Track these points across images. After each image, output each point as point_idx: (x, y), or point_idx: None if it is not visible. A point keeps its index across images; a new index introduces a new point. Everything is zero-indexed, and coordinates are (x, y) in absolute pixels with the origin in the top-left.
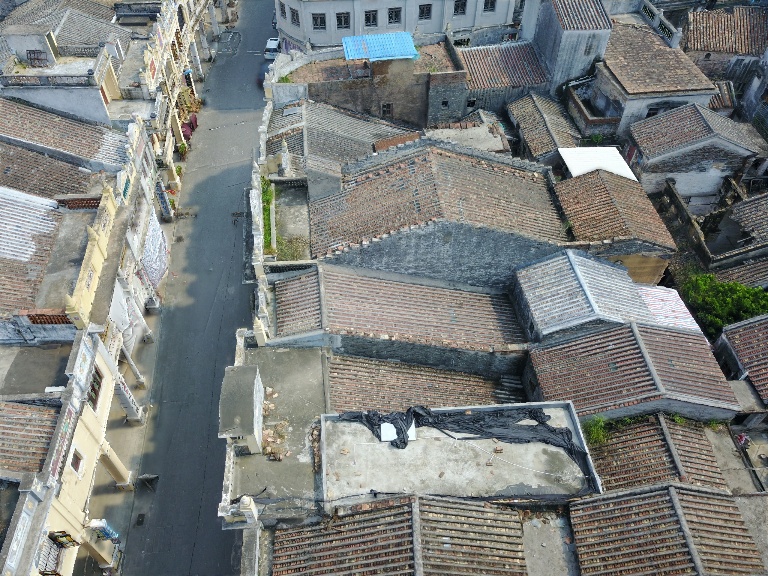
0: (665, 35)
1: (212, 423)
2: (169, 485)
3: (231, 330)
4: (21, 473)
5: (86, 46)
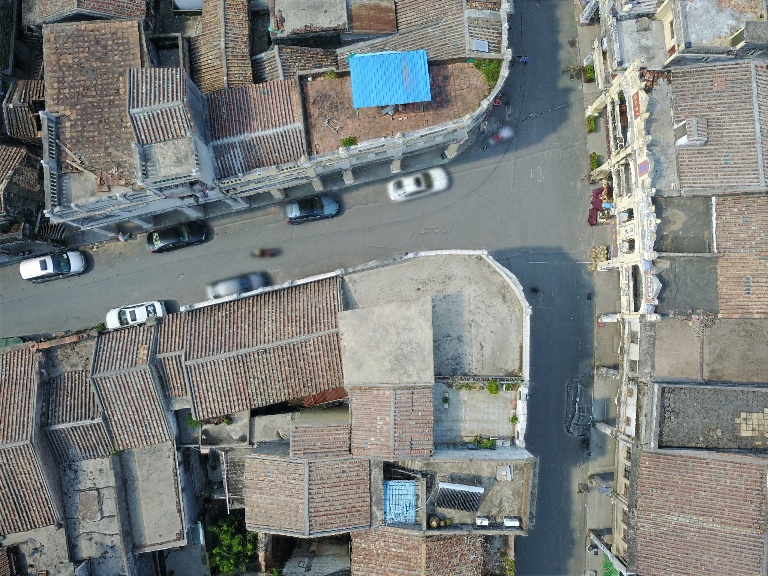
0: (54, 138)
1: None
2: None
3: None
4: None
5: (705, 46)
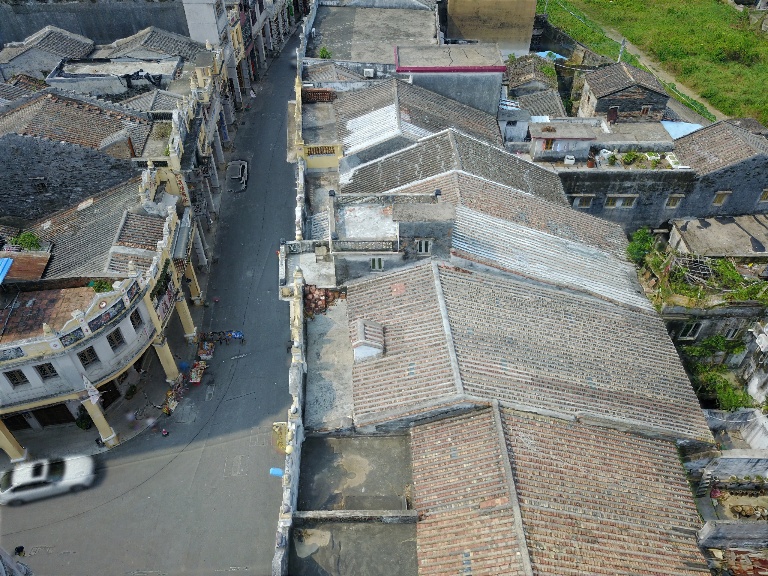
0: None
1: (264, 197)
2: (289, 175)
3: (251, 245)
4: (308, 58)
5: (357, 238)
